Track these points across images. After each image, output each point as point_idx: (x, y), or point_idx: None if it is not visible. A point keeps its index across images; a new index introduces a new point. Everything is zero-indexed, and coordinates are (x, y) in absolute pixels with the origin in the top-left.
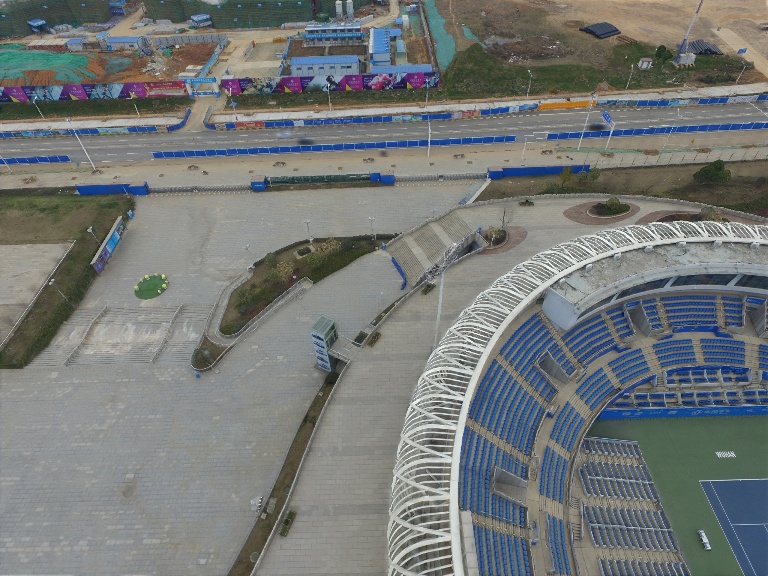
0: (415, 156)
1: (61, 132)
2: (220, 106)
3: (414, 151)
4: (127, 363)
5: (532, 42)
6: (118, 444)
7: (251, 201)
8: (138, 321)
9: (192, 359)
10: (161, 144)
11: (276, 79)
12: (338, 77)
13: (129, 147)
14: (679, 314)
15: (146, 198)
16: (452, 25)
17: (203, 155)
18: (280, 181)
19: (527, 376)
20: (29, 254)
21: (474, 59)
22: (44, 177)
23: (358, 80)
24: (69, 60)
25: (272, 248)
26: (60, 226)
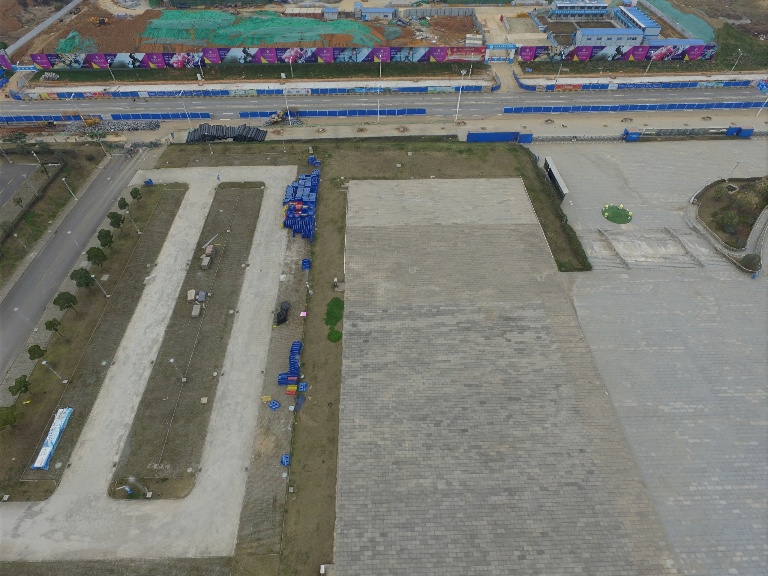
0: (744, 116)
1: (392, 89)
2: (518, 71)
3: (739, 112)
4: (679, 268)
5: (767, 23)
6: (739, 324)
7: (633, 149)
8: (641, 239)
9: (741, 264)
10: (496, 102)
11: (571, 47)
12: (627, 47)
13: (466, 104)
14: None
15: (533, 145)
16: (680, 6)
17: (548, 111)
18: (643, 134)
19: None
20: (493, 186)
21: (733, 36)
22: (413, 127)
23: (644, 51)
24: (356, 26)
25: (693, 186)
26: (493, 165)
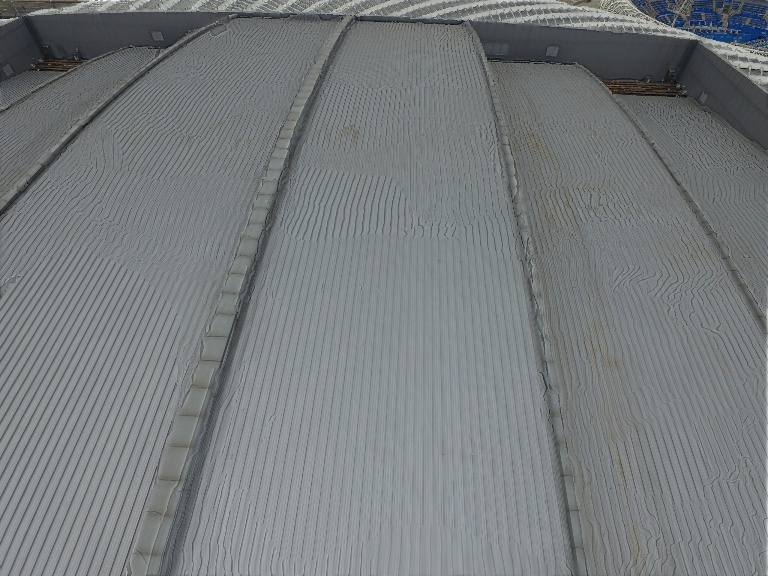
0: None
1: None
2: None
3: None
4: None
5: None
6: None
7: None
8: None
9: None
10: None
11: None
12: None
13: None
14: (697, 5)
15: None
16: None
17: None
18: None
19: (638, 8)
20: None
21: None
22: None
23: None
24: None
25: None
26: None
